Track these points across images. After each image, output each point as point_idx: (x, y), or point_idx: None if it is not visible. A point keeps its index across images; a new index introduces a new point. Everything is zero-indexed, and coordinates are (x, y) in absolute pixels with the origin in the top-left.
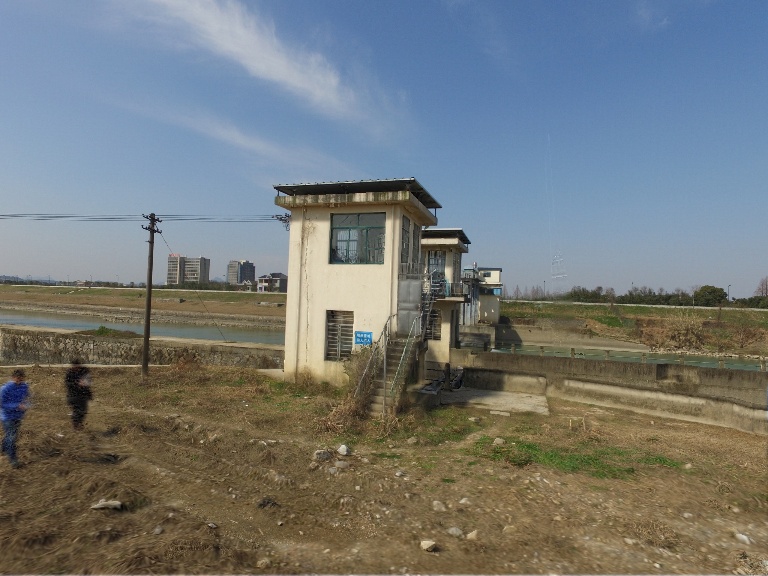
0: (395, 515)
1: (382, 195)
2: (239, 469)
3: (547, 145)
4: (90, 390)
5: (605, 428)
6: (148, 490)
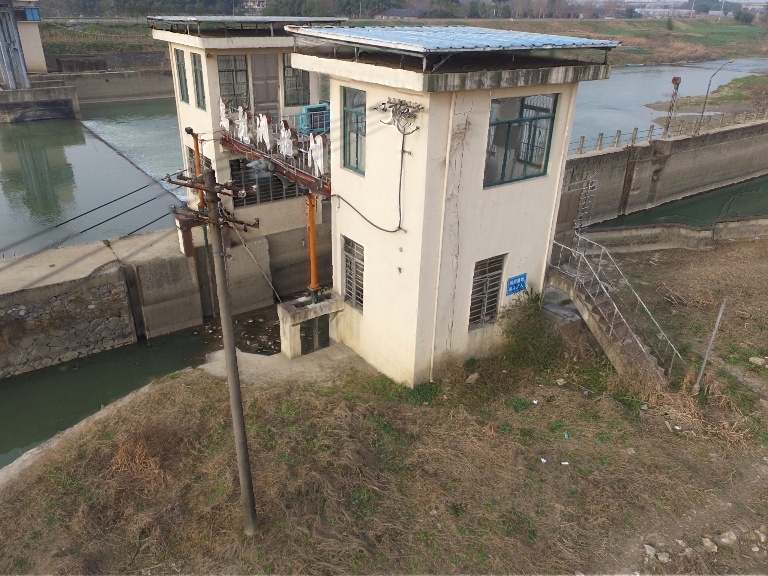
0: None
1: None
2: None
3: None
4: None
5: None
6: None
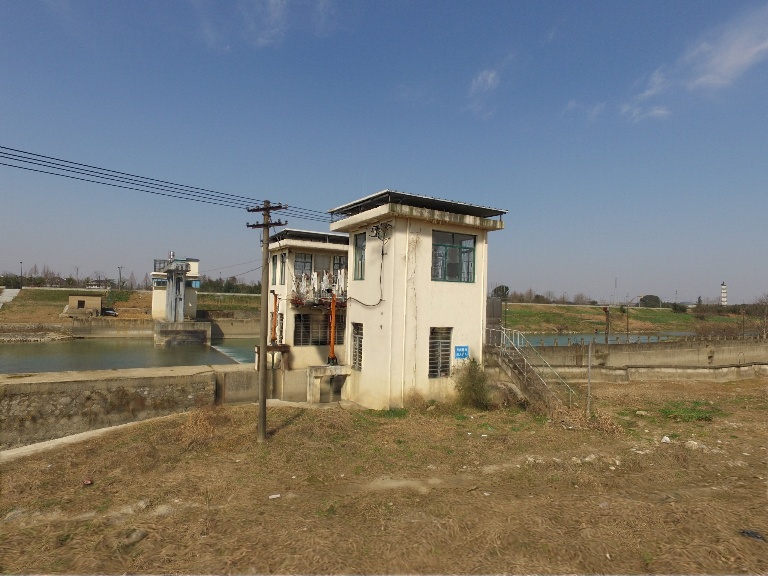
0: None
1: (486, 221)
2: (713, 469)
3: (365, 164)
4: (317, 474)
5: None
6: None
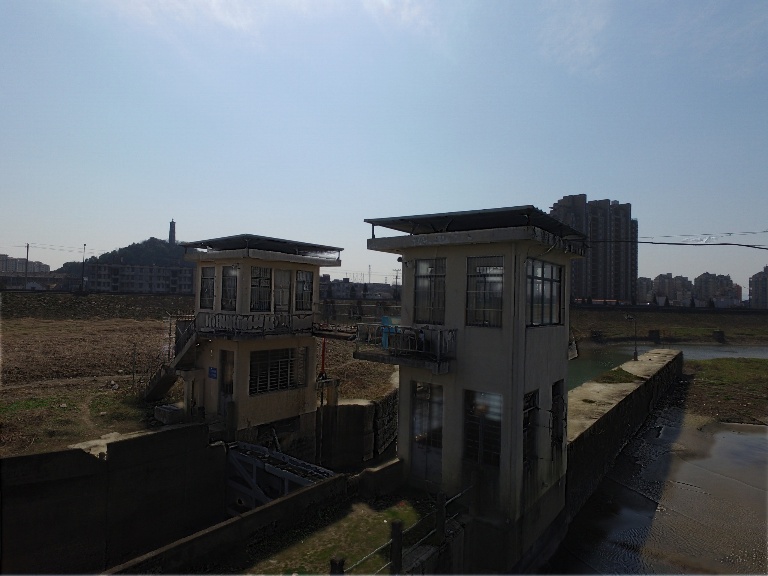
0: (59, 384)
1: None
2: None
3: None
4: None
5: (5, 454)
6: (131, 375)
